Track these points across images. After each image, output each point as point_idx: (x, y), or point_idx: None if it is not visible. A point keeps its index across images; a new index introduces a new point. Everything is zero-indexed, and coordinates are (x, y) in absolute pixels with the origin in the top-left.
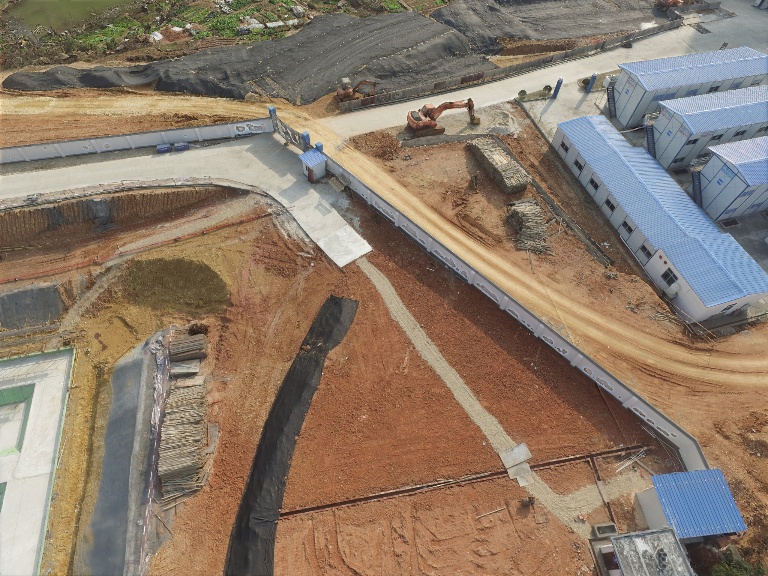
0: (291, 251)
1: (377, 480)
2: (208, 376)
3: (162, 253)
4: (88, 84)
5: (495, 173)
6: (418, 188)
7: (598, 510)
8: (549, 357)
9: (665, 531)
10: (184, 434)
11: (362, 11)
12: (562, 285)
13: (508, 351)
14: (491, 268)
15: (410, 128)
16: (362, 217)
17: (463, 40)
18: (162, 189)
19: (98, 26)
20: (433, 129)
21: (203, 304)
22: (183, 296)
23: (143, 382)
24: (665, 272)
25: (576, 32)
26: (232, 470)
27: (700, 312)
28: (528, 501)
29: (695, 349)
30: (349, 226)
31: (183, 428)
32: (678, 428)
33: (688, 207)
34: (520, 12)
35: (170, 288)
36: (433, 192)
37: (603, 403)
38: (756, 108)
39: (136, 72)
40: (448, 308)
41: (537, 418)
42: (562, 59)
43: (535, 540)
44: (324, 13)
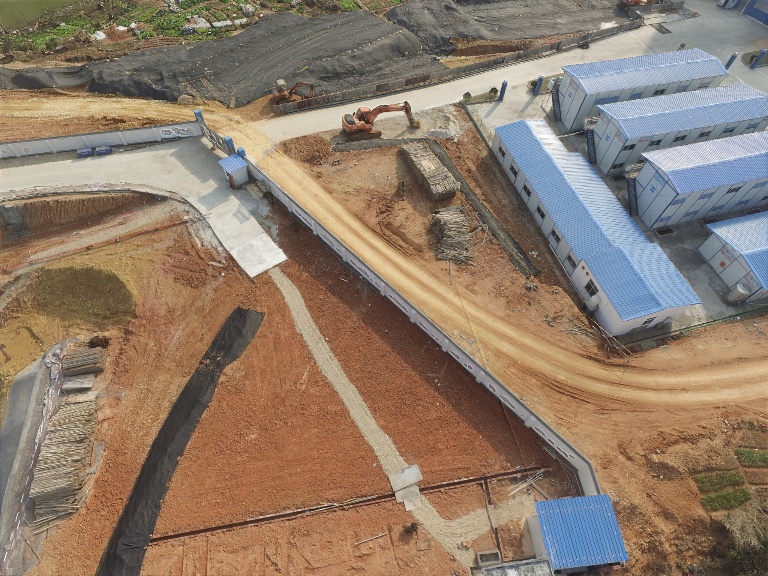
0: (202, 260)
1: (257, 503)
2: (102, 391)
3: (73, 262)
4: (20, 85)
5: (423, 179)
6: (343, 195)
7: (484, 536)
8: (455, 373)
9: (541, 562)
10: (63, 454)
11: (316, 10)
12: (479, 297)
13: (413, 366)
14: (407, 279)
15: (346, 132)
16: (281, 225)
17: (413, 40)
18: (77, 195)
19: (51, 24)
20: (368, 133)
21: (110, 315)
22: (92, 306)
23: (33, 398)
24: (588, 283)
25: (533, 32)
26: (112, 491)
27: (618, 326)
28: (410, 527)
29: (610, 364)
30: (266, 234)
31: (63, 447)
32: (573, 450)
33: (618, 215)
34: (478, 11)
35: (80, 298)
36: (358, 199)
37: (505, 422)
38: (697, 112)
39: (71, 73)
40: (356, 321)
41: (433, 438)
42: (515, 60)
43: (414, 568)
44: (276, 12)
